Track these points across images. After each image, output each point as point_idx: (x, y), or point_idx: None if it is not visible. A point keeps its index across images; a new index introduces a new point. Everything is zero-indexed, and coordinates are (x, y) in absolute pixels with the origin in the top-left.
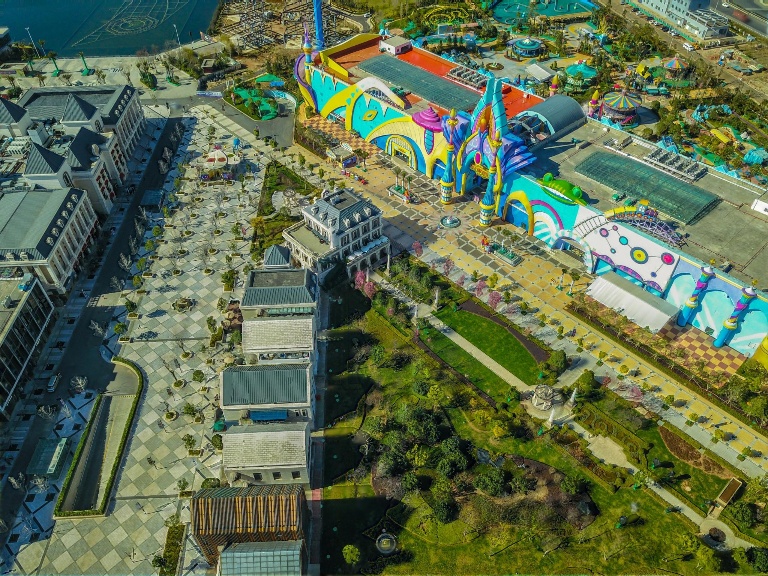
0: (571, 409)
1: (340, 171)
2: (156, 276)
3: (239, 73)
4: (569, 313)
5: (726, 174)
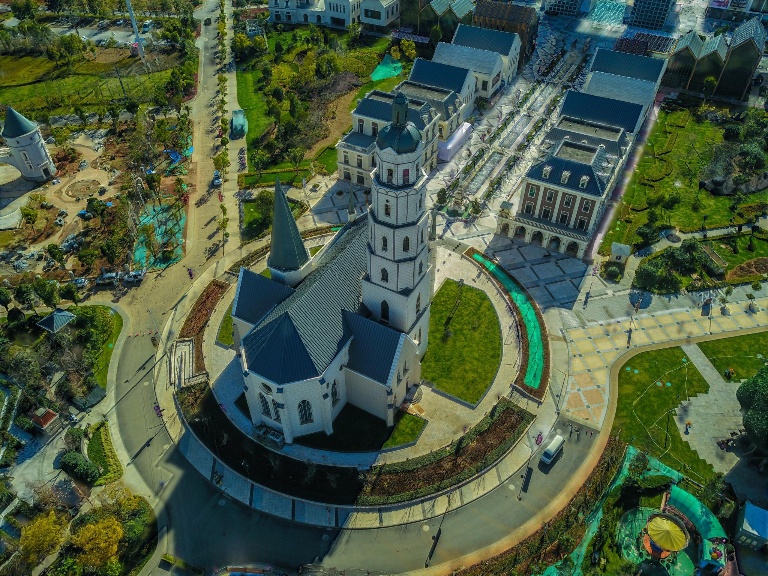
0: None
1: None
2: None
3: None
4: None
5: None
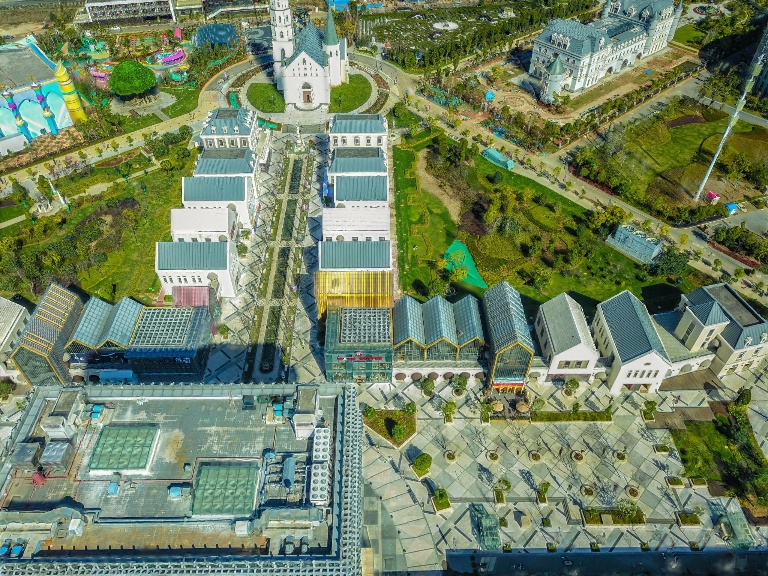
0: None
1: None
2: None
3: None
4: None
5: None
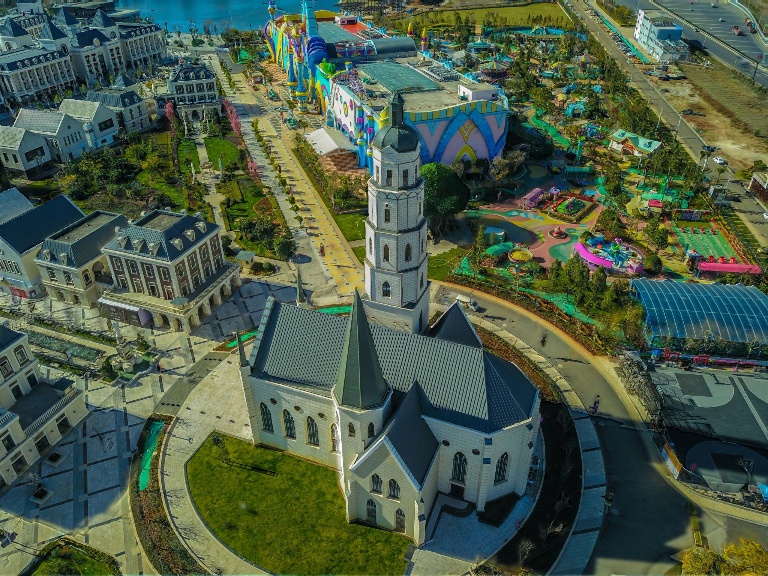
0: (220, 180)
1: (248, 84)
2: None
3: (257, 45)
4: (291, 151)
5: (467, 78)
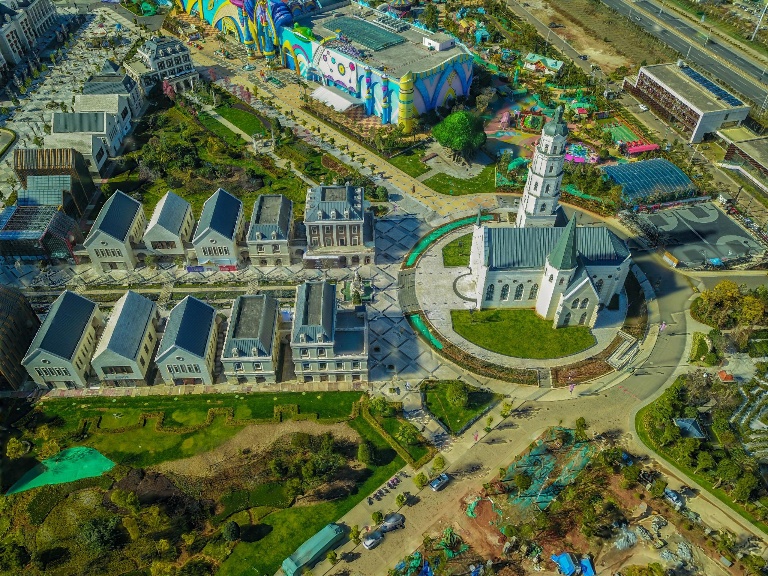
0: (273, 148)
1: (186, 42)
2: (40, 93)
3: None
4: (300, 109)
5: (419, 27)
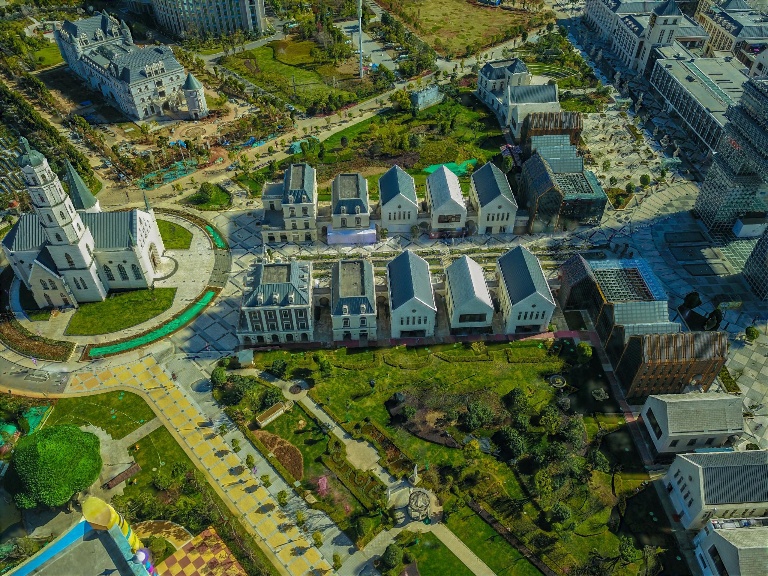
0: None
1: None
2: None
3: None
4: None
5: None
